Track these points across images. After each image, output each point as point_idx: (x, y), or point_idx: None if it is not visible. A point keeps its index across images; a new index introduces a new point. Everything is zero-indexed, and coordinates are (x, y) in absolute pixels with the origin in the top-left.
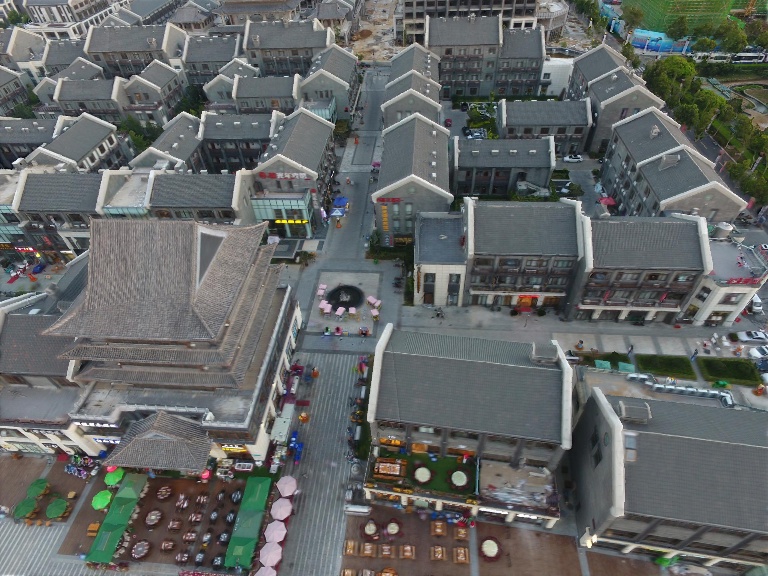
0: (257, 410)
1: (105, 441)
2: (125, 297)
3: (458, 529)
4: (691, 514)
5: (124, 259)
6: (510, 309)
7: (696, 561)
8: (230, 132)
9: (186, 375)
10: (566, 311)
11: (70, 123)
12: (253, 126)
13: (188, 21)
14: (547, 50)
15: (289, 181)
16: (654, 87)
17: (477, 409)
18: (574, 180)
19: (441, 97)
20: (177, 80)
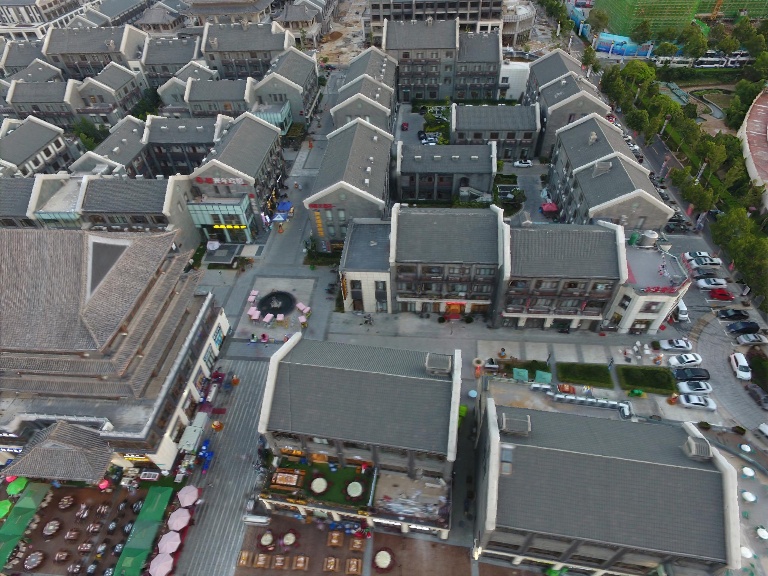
0: (160, 419)
1: (9, 450)
2: (15, 307)
3: (354, 540)
4: (562, 528)
5: (15, 268)
6: (439, 316)
7: (585, 573)
8: (175, 136)
9: (85, 384)
10: (493, 318)
11: (16, 126)
12: (198, 130)
13: (156, 22)
14: (508, 54)
15: (227, 186)
16: (610, 92)
17: (367, 420)
18: (522, 185)
19: (401, 100)
20: (134, 82)
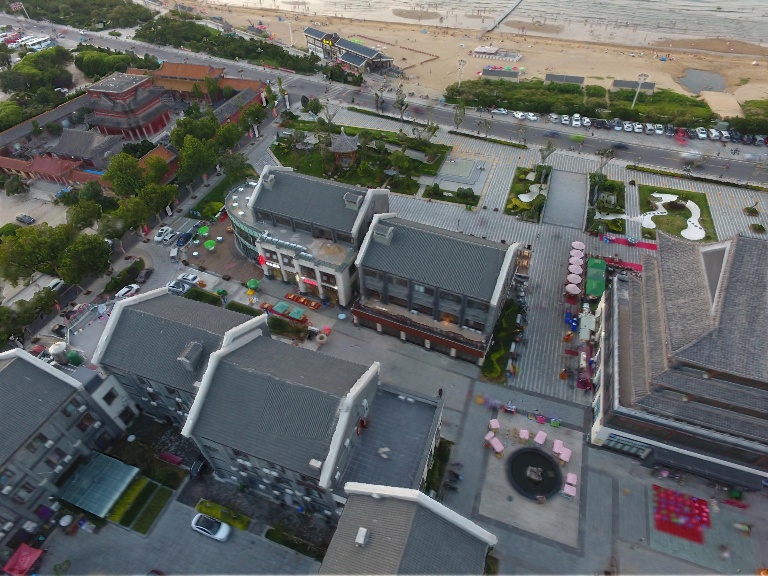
0: None
1: None
2: None
3: None
4: None
5: None
6: None
7: None
8: None
9: None
10: None
11: None
12: None
13: None
14: None
15: None
16: None
17: None
18: None
19: None
20: None
